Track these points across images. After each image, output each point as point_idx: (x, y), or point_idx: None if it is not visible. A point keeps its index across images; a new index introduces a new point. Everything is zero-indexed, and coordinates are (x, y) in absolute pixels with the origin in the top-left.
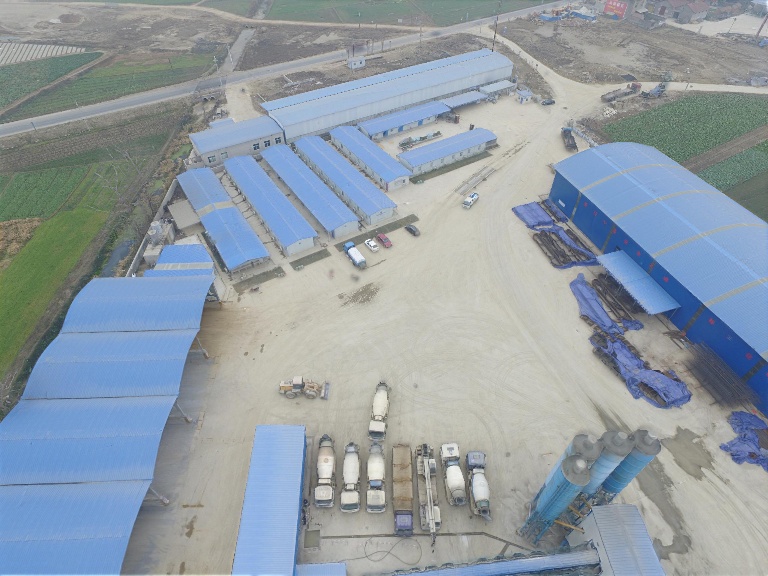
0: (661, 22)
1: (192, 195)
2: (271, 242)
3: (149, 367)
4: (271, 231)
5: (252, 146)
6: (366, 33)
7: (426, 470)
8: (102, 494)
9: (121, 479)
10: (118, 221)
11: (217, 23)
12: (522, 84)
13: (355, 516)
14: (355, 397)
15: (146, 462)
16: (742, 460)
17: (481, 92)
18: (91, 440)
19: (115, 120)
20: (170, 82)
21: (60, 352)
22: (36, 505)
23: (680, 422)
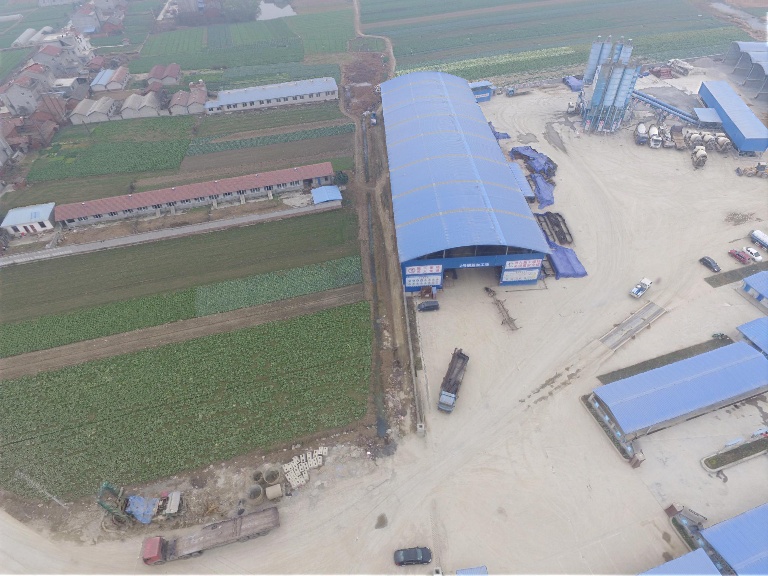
0: None
1: None
2: None
3: None
4: None
5: None
6: None
7: None
8: None
9: None
10: None
11: None
12: None
13: None
14: None
15: None
16: None
17: None
18: None
19: None
20: None
21: None
22: None
23: (524, 145)
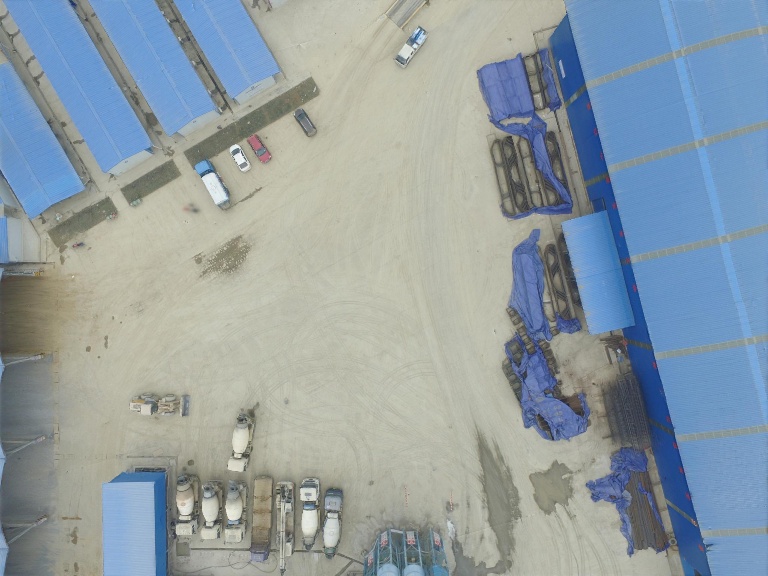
0: None
1: None
2: None
3: None
4: None
5: None
6: None
7: (281, 514)
8: None
9: None
10: None
11: None
12: None
13: None
14: (219, 413)
15: None
16: (600, 499)
17: None
18: None
19: None
20: None
21: None
22: None
23: (560, 456)
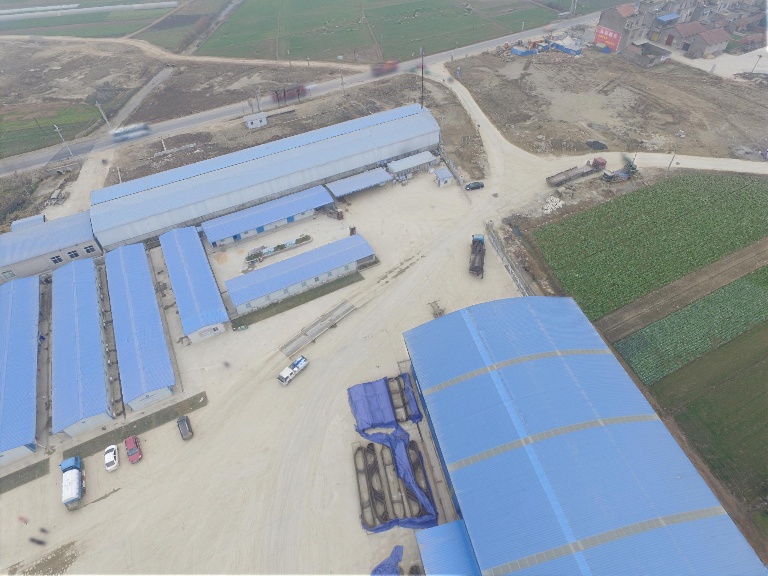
0: (664, 57)
1: None
2: None
3: None
4: None
5: (50, 259)
6: (294, 74)
7: None
8: None
9: None
10: None
11: (136, 61)
12: (452, 154)
13: None
14: None
15: None
16: None
17: (389, 169)
18: None
19: None
20: (36, 145)
21: None
22: None
23: None
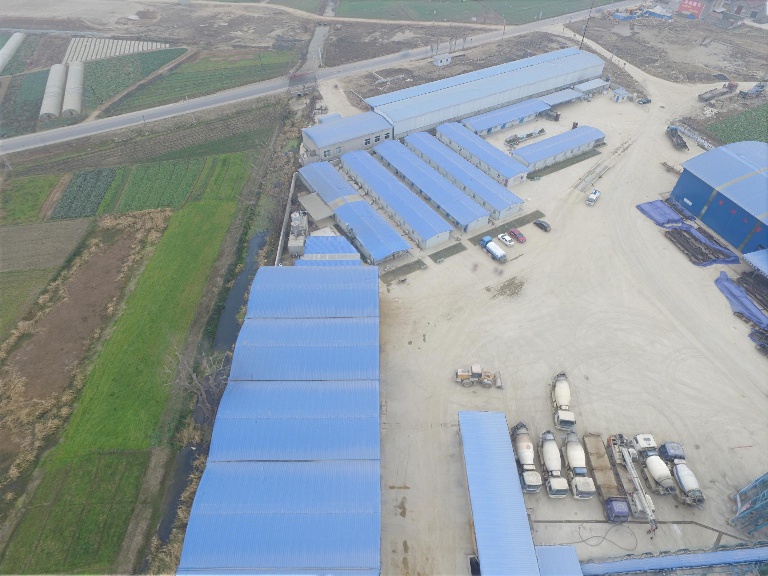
0: (740, 22)
1: (319, 188)
2: (404, 235)
3: (345, 352)
4: (403, 224)
5: (364, 141)
6: (442, 31)
7: (628, 459)
8: (338, 472)
9: (350, 458)
10: (248, 212)
11: (291, 20)
12: (612, 83)
13: (561, 502)
14: (529, 387)
15: (371, 443)
16: None
17: (575, 90)
18: (313, 420)
19: (217, 114)
20: (260, 78)
21: (255, 336)
22: (279, 480)
23: None
